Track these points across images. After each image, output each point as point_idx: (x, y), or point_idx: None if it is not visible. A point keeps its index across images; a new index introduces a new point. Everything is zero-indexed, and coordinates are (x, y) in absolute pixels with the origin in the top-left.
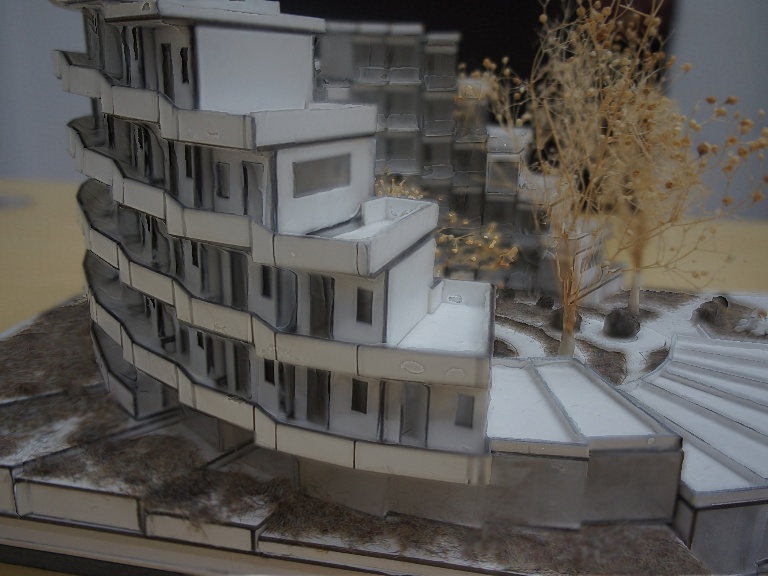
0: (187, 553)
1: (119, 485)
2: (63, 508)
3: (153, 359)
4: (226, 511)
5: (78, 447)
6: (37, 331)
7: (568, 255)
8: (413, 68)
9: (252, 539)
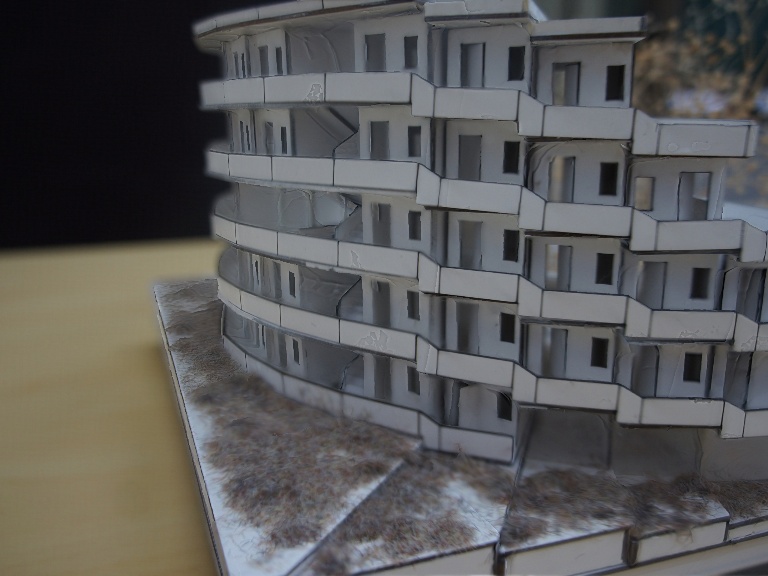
0: (659, 570)
1: (599, 523)
2: (546, 570)
3: (580, 387)
4: (691, 514)
5: (508, 505)
6: (232, 418)
7: None
8: None
9: (726, 530)
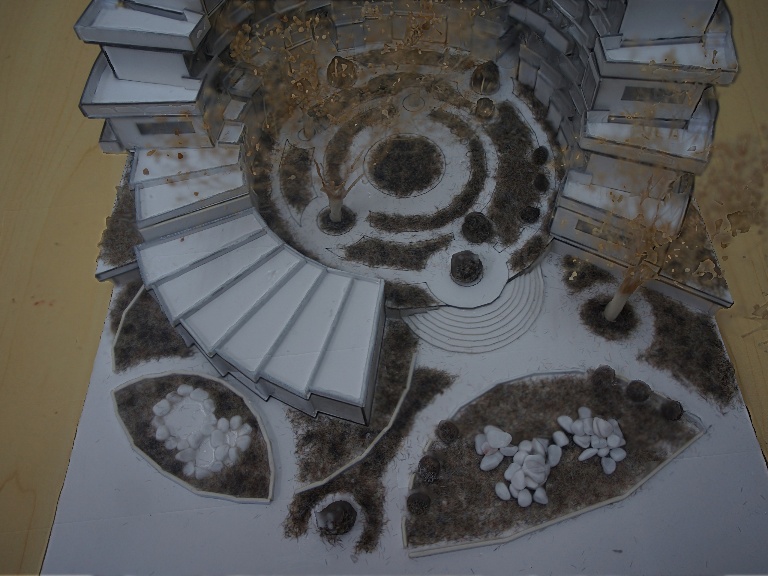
0: None
1: None
2: None
3: None
4: None
5: None
6: None
7: None
8: None
9: None
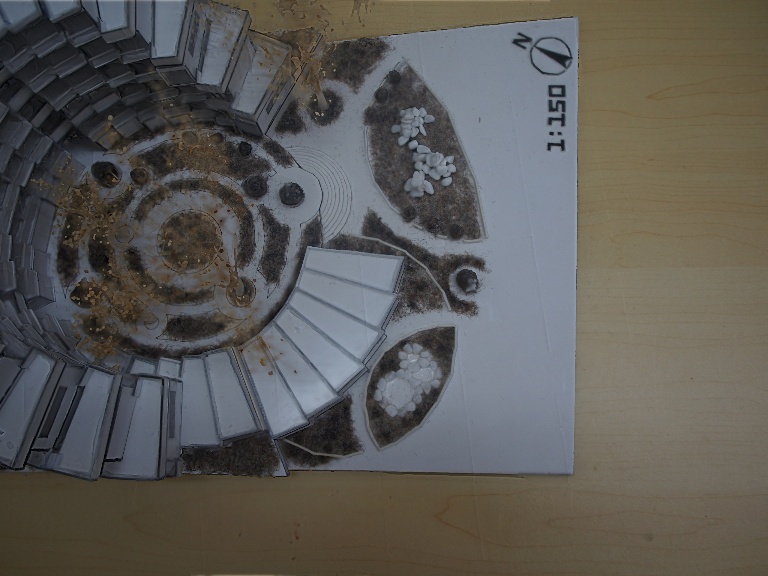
0: None
1: None
2: None
3: None
4: None
5: None
6: None
7: (251, 121)
8: (51, 36)
9: None
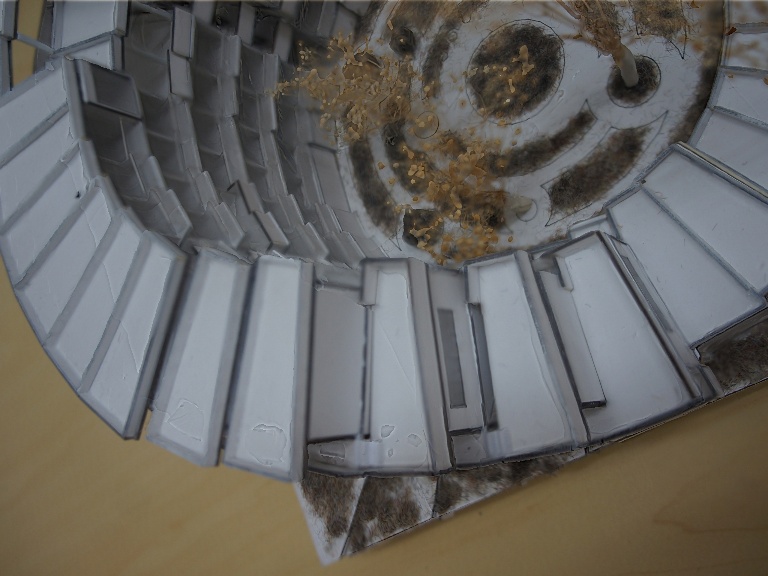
0: None
1: (491, 487)
2: None
3: None
4: (558, 456)
5: (439, 477)
6: None
7: None
8: None
9: None
